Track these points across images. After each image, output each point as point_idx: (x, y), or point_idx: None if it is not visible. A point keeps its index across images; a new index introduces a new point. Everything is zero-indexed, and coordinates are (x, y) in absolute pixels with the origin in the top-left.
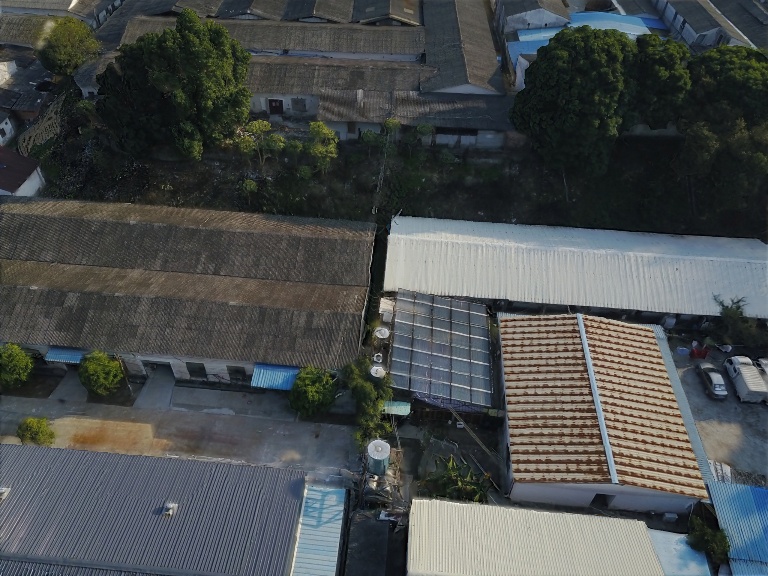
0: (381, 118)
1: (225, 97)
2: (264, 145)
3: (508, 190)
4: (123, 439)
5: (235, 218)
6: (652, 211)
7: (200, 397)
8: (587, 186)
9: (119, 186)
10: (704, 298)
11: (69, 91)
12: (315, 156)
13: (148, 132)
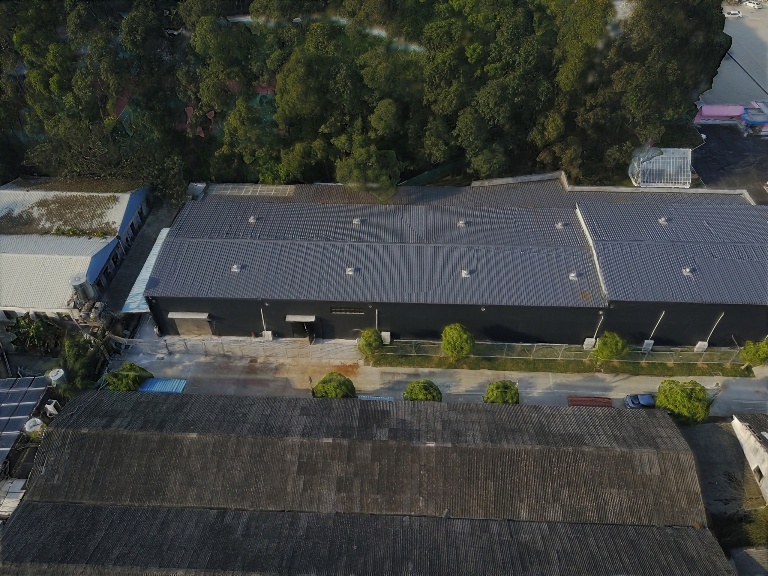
0: None
1: None
2: None
3: None
4: (313, 376)
5: None
6: None
7: None
8: None
9: None
10: None
11: None
12: None
13: None
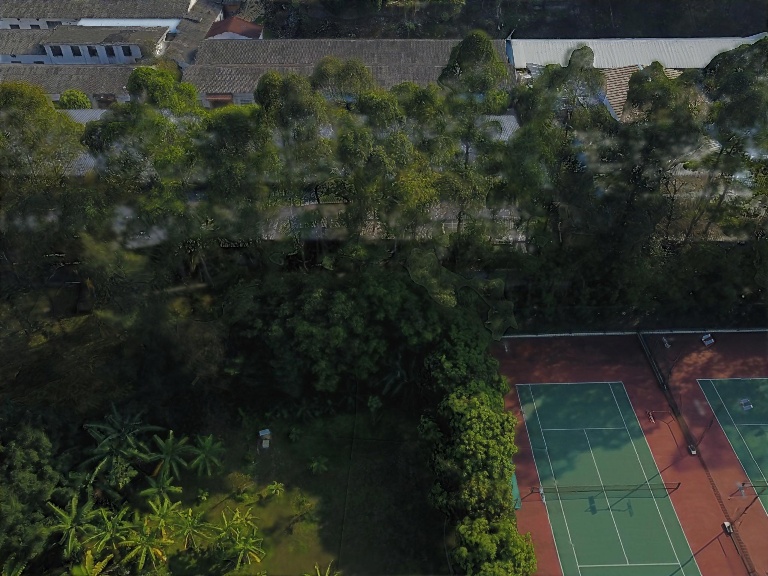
0: None
1: None
2: (417, 1)
3: (574, 23)
4: None
5: (411, 39)
6: (669, 27)
7: None
8: (625, 17)
9: (320, 37)
10: (709, 59)
11: None
12: (448, 8)
13: None
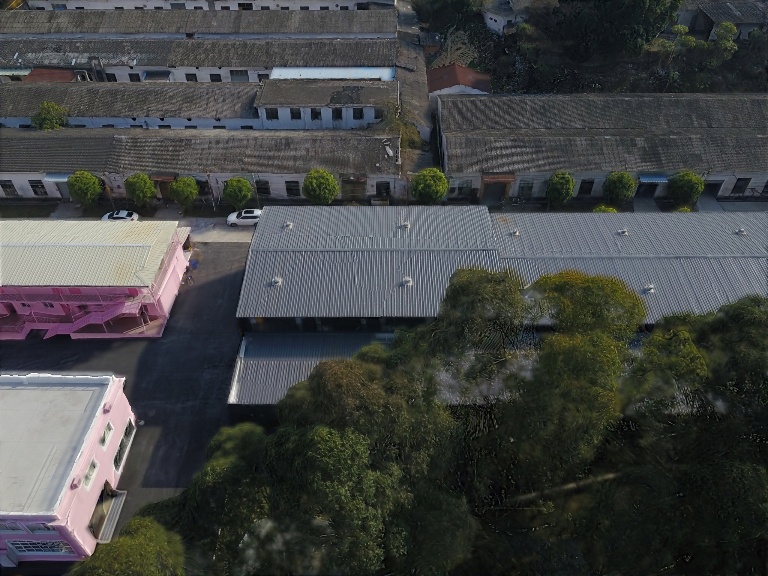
0: (761, 20)
1: (663, 6)
2: (678, 45)
3: None
4: None
5: None
6: None
7: (743, 206)
8: None
9: (558, 88)
10: None
11: (469, 26)
12: (711, 53)
13: (604, 37)
